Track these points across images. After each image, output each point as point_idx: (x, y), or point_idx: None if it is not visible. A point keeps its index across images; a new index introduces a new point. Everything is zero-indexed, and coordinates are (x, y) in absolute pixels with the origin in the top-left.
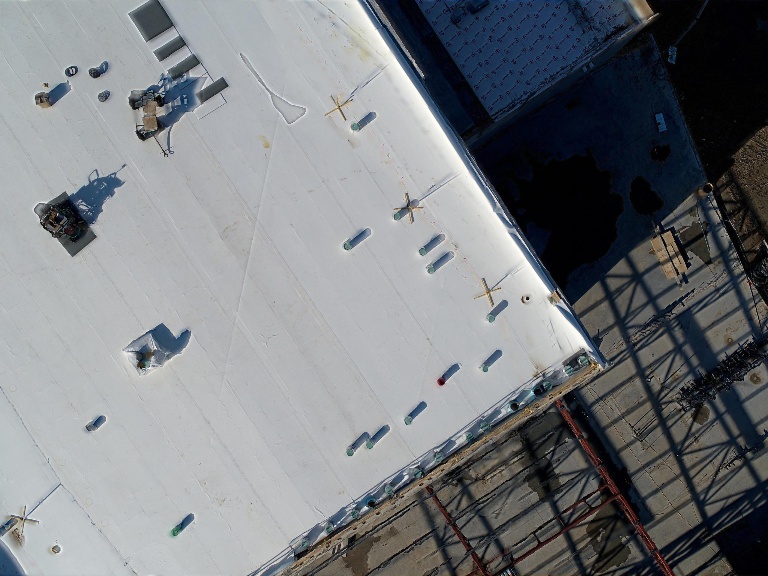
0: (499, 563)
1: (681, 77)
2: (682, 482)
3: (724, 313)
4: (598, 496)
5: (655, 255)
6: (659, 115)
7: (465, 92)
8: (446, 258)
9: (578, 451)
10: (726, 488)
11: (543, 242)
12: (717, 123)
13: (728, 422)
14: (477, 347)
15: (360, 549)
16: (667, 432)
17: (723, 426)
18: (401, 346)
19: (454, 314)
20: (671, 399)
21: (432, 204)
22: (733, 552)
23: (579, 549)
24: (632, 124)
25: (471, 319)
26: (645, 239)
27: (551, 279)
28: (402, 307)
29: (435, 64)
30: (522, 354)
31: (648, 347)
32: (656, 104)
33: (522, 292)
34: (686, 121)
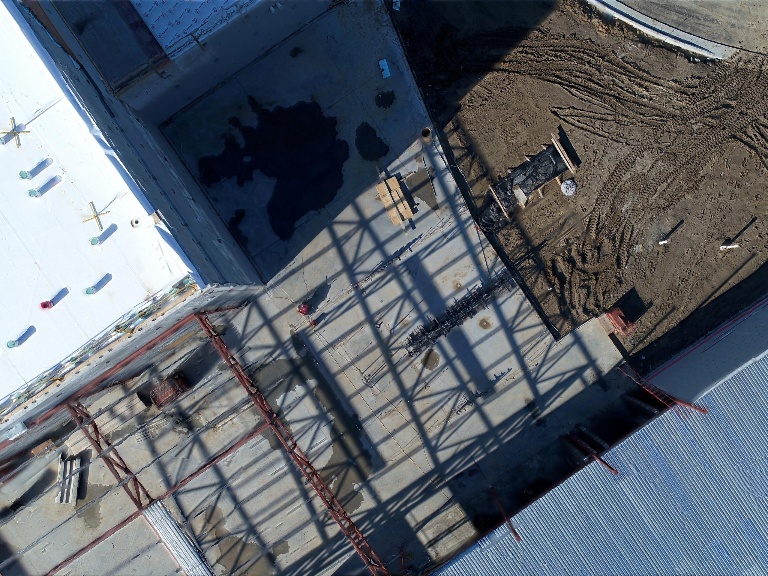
0: (231, 511)
1: (406, 24)
2: (413, 428)
3: (452, 258)
4: (329, 443)
5: (381, 201)
6: (382, 61)
7: (141, 31)
8: (53, 182)
9: (309, 398)
10: (458, 434)
11: (269, 189)
12: (443, 69)
13: (458, 367)
14: (86, 271)
15: (92, 499)
16: (397, 378)
17: (453, 371)
18: (9, 270)
19: (62, 238)
20: (401, 345)
21: (38, 128)
22: (466, 498)
23: (312, 496)
24: (356, 70)
25: (79, 243)
26: (371, 185)
27: (151, 200)
28: (9, 231)
29: (110, 3)
30: (133, 277)
31: (376, 293)
32: (380, 50)
33: (131, 215)
34: (412, 67)
